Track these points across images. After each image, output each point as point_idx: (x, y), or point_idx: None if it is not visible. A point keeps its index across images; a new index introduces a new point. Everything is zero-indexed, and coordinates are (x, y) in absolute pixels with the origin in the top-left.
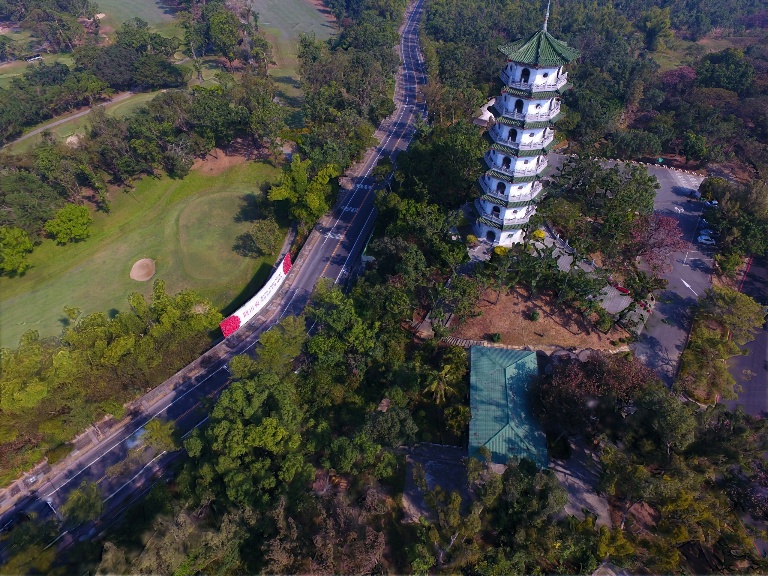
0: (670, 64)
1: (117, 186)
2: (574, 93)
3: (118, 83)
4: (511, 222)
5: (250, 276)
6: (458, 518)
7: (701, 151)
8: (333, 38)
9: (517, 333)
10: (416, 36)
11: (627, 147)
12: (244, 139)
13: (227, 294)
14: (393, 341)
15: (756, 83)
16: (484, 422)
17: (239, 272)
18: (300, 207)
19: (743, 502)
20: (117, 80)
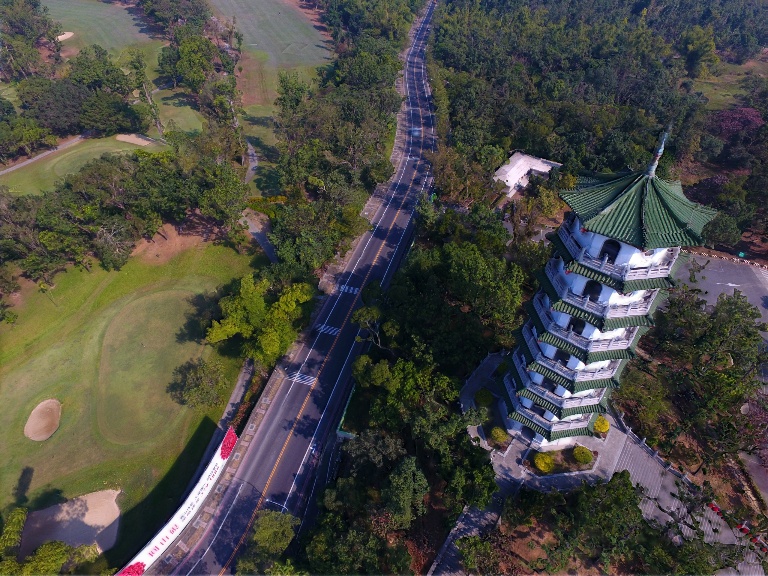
0: (716, 94)
1: (33, 281)
2: (619, 151)
3: (64, 128)
4: (563, 427)
5: (184, 441)
6: None
7: None
8: (327, 64)
9: None
10: (423, 60)
11: None
12: None
13: (147, 475)
14: None
15: None
16: None
17: (170, 433)
18: (254, 346)
19: None
20: (62, 124)
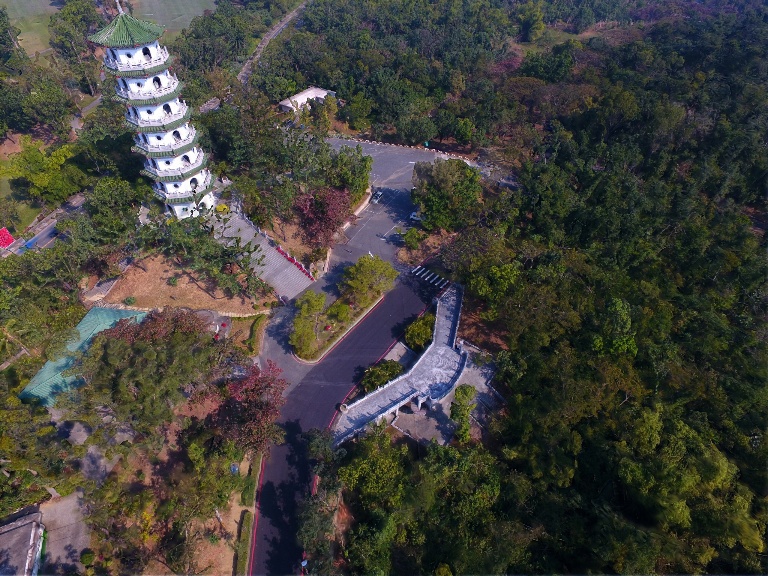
0: None
1: None
2: (380, 81)
3: None
4: (174, 196)
5: None
6: None
7: (466, 135)
8: None
9: (154, 297)
10: None
11: (400, 132)
12: (50, 125)
13: None
14: (31, 304)
15: (572, 73)
16: (47, 371)
17: None
18: (34, 186)
19: (224, 435)
20: None
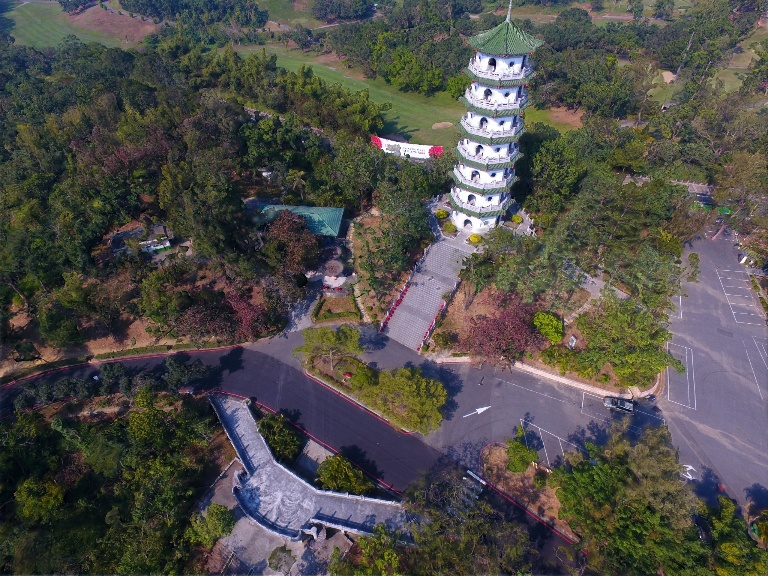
0: None
1: None
2: None
3: None
4: None
5: None
6: (191, 134)
7: None
8: None
9: None
10: None
11: None
12: None
13: None
14: None
15: None
16: None
17: None
18: None
19: None
20: None
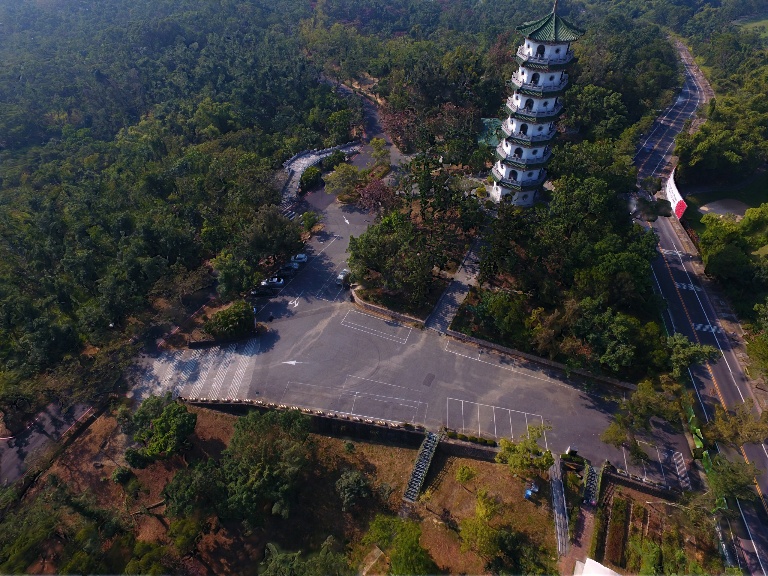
0: None
1: None
2: None
3: None
4: None
5: None
6: None
7: None
8: None
9: None
10: None
11: None
12: None
13: None
14: None
15: None
16: None
17: None
18: None
19: None
20: None
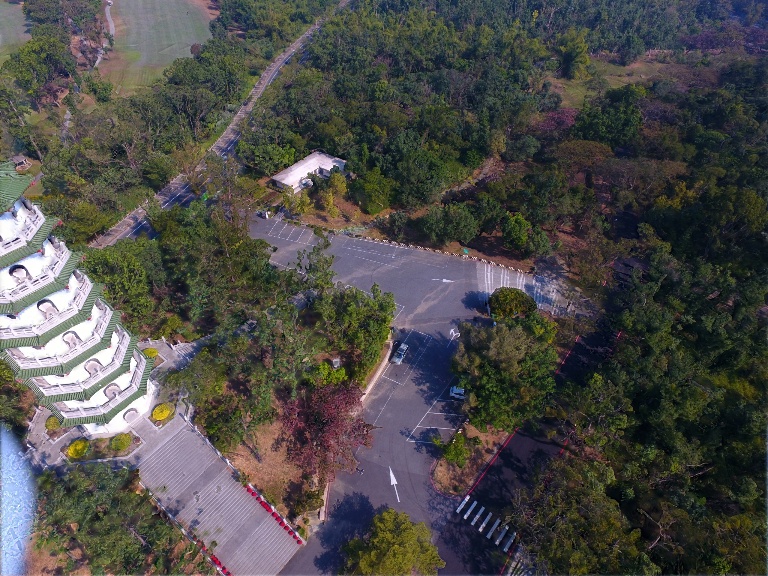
0: None
1: None
2: (401, 150)
3: None
4: (77, 414)
5: None
6: None
7: (519, 240)
8: None
9: None
10: (300, 60)
11: (430, 231)
12: None
13: None
14: None
15: (642, 133)
16: None
17: None
18: None
19: None
20: None
